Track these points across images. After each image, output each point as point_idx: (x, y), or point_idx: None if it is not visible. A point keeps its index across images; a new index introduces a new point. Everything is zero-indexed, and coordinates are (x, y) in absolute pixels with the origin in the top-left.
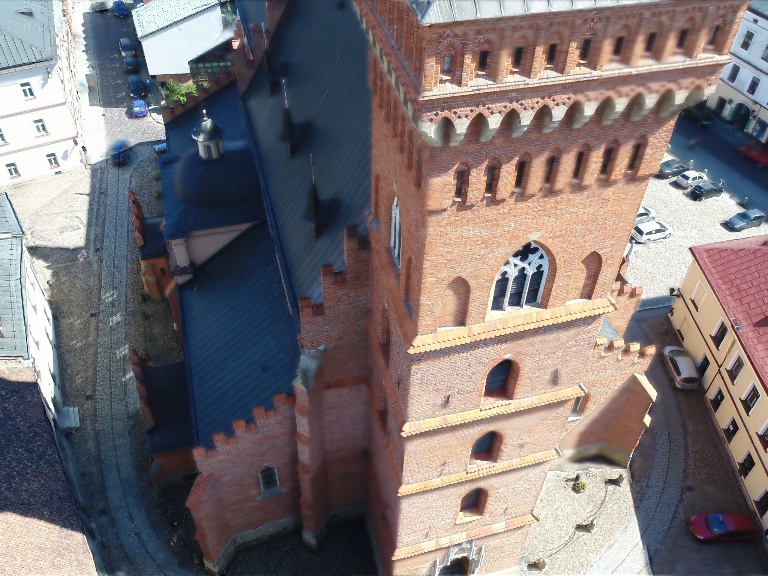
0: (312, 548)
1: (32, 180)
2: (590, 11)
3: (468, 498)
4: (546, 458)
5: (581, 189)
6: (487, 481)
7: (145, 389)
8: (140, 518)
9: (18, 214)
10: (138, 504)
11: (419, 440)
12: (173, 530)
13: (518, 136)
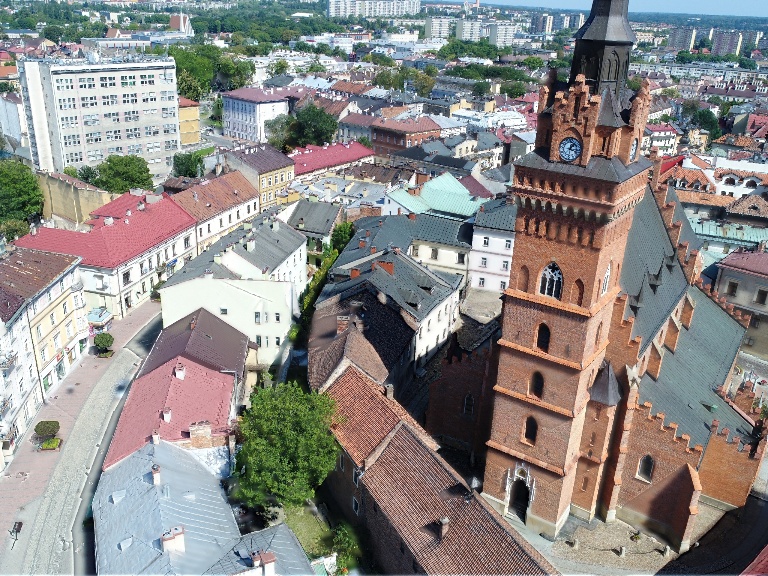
0: (471, 466)
1: (488, 291)
2: (561, 174)
3: (531, 429)
4: (566, 414)
5: (571, 245)
6: (537, 414)
7: (451, 353)
8: (415, 415)
9: (470, 300)
10: (419, 411)
11: (506, 354)
12: (423, 426)
13: (544, 211)
